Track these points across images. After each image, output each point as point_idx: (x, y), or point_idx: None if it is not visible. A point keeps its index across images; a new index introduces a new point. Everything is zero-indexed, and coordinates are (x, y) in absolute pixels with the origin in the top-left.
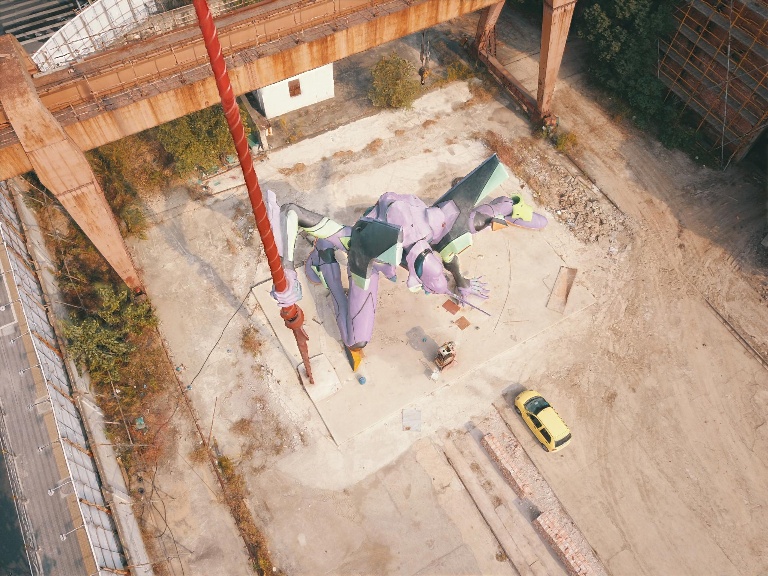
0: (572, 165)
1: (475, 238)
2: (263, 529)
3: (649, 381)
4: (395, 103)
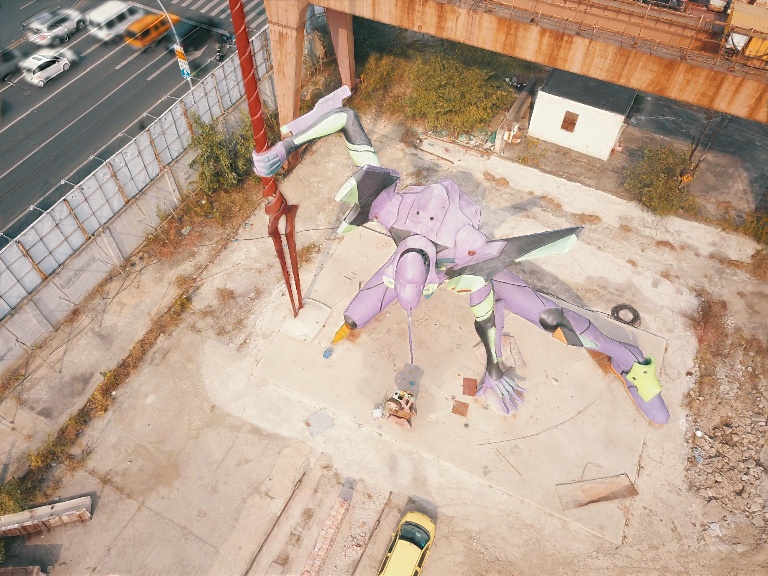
0: None
1: (572, 363)
2: (145, 364)
3: None
4: (647, 198)
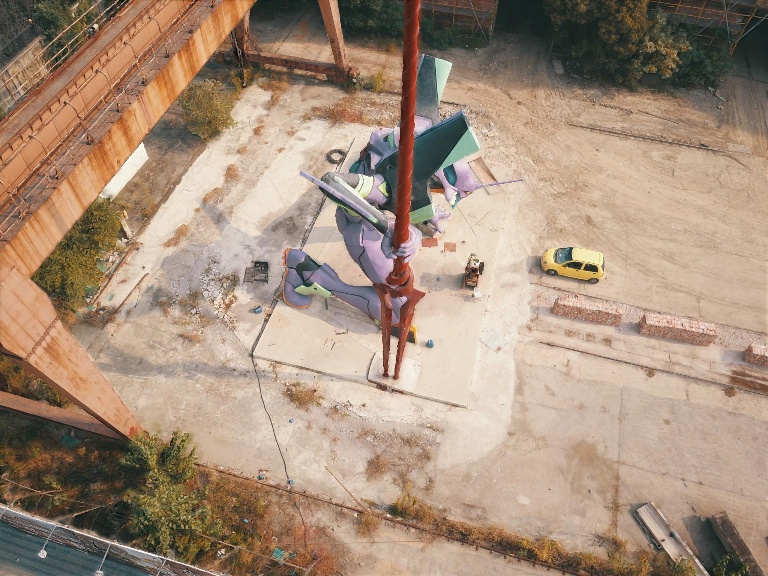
0: (397, 96)
1: None
2: (488, 524)
3: (595, 194)
4: (220, 126)
